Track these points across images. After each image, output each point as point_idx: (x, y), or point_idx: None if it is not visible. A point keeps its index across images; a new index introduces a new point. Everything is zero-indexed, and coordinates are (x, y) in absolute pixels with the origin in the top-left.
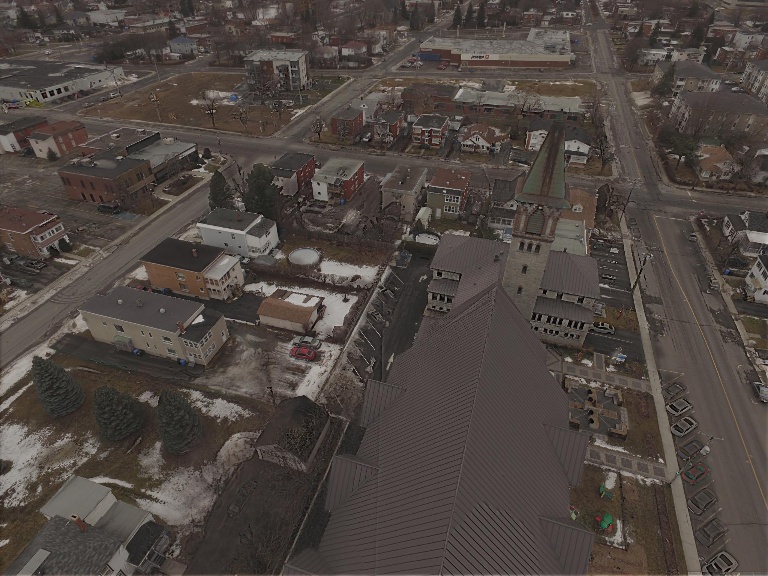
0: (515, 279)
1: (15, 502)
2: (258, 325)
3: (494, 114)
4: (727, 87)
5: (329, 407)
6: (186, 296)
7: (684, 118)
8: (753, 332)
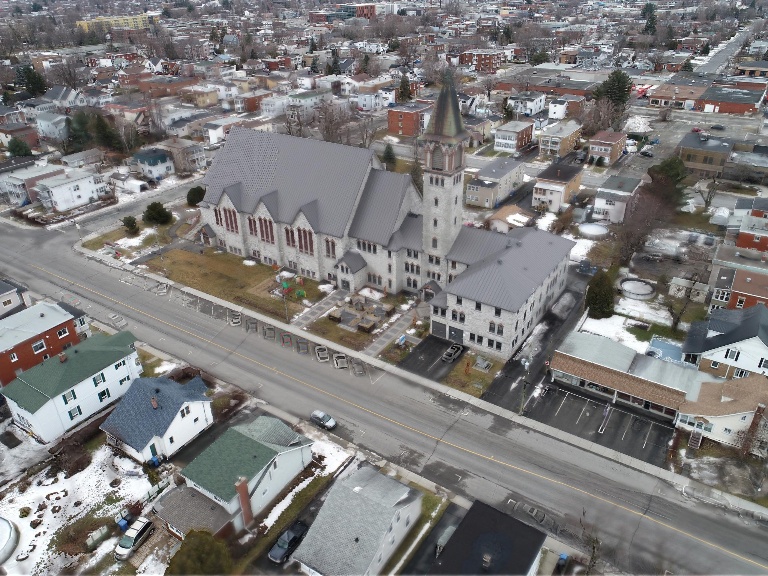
0: None
1: None
2: None
3: None
4: None
5: None
6: None
7: None
8: None
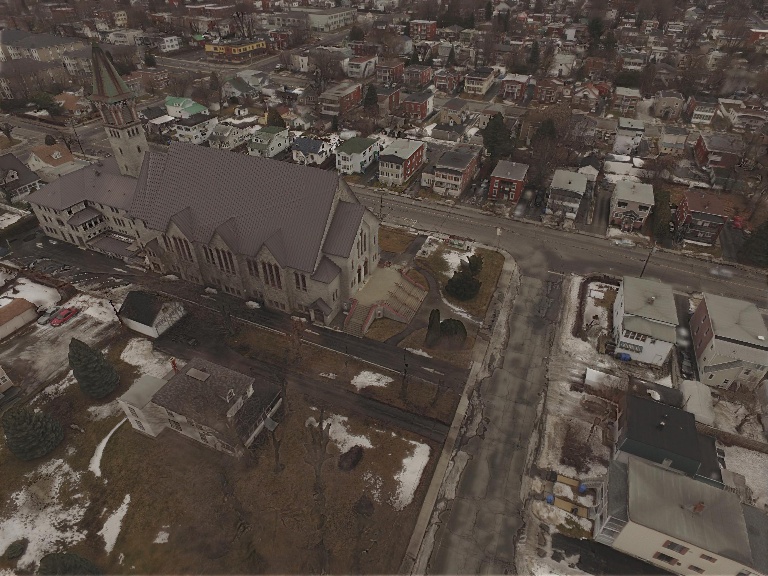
0: (138, 159)
1: (80, 513)
2: None
3: None
4: None
5: None
6: None
7: (4, 88)
8: None
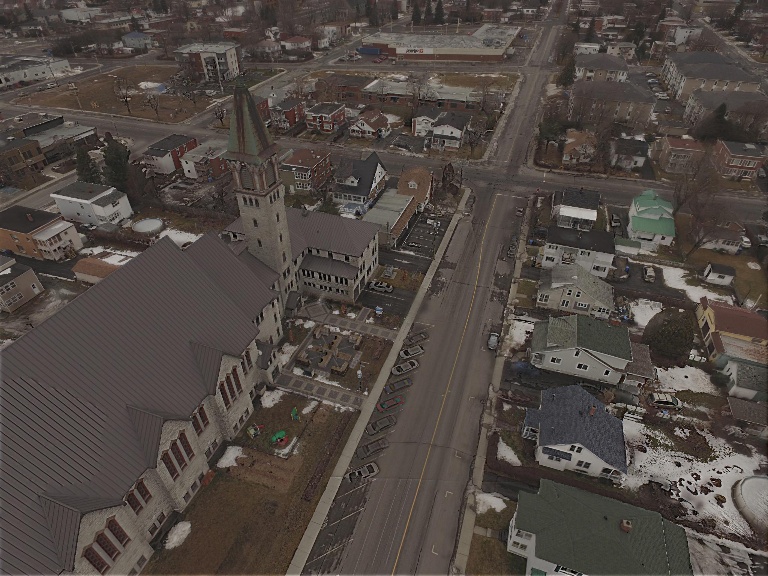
0: (252, 232)
1: None
2: (75, 281)
3: (399, 103)
4: (646, 79)
5: None
6: (25, 257)
7: (571, 106)
8: (522, 293)
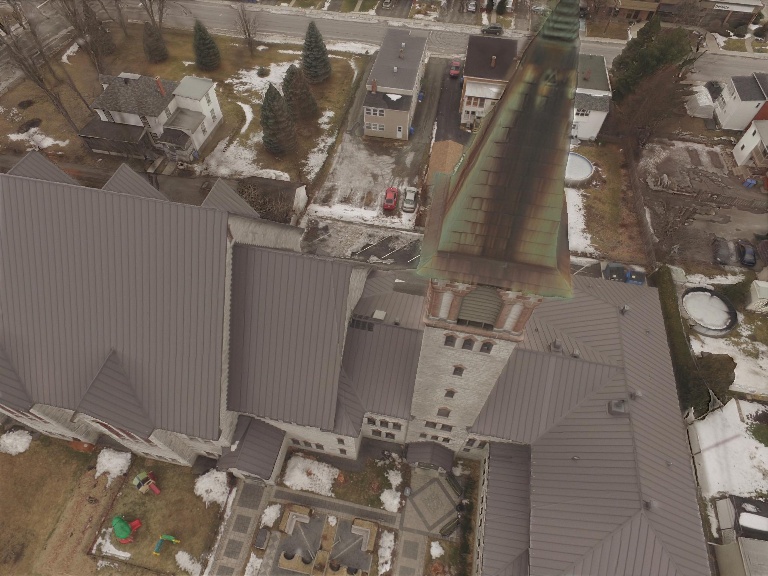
0: None
1: (237, 88)
2: (429, 156)
3: None
4: None
5: (314, 230)
6: None
7: None
8: None
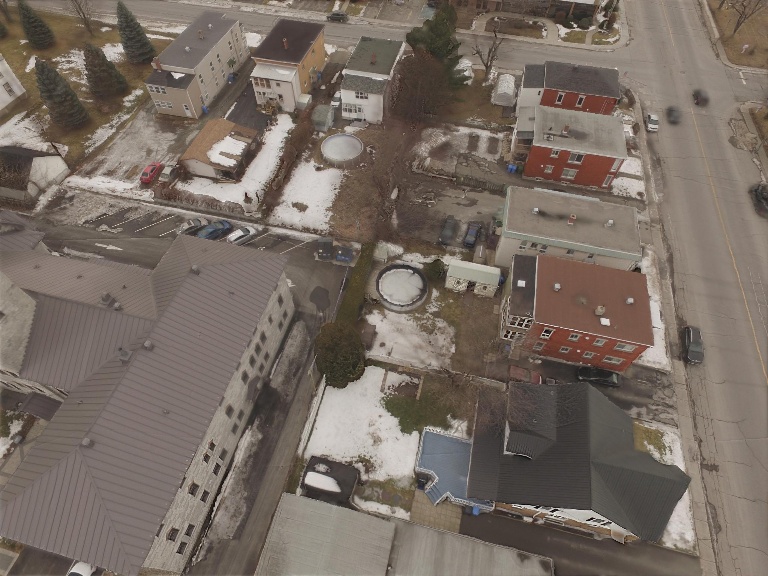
0: None
1: (61, 66)
2: None
3: None
4: None
5: (59, 199)
6: None
7: None
8: None
